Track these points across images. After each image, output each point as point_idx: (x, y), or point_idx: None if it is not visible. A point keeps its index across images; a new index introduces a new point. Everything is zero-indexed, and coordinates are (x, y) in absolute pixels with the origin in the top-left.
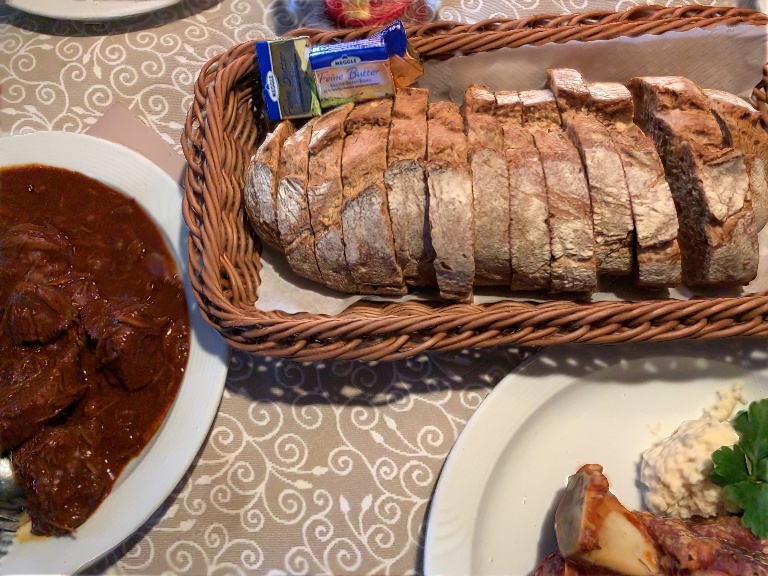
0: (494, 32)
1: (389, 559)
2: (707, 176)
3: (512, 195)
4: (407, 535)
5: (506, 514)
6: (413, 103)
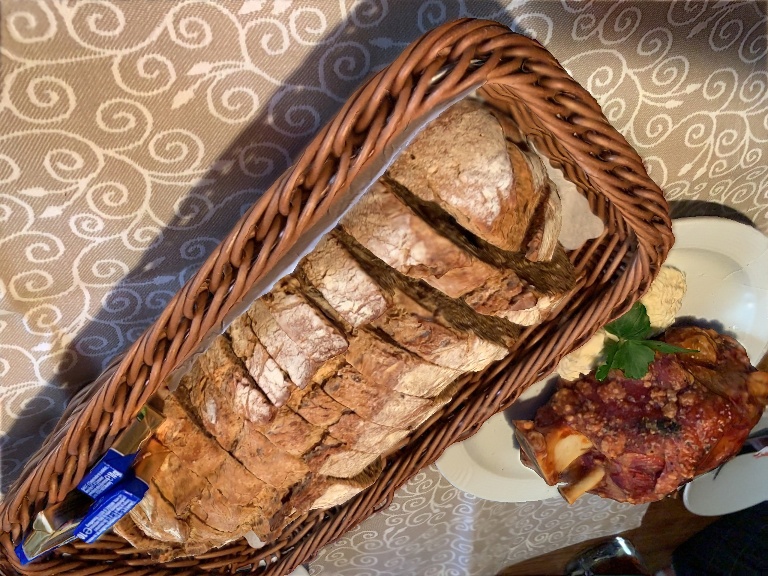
0: (175, 347)
1: (436, 484)
2: (508, 311)
3: None
4: (436, 472)
5: (483, 435)
6: (203, 458)
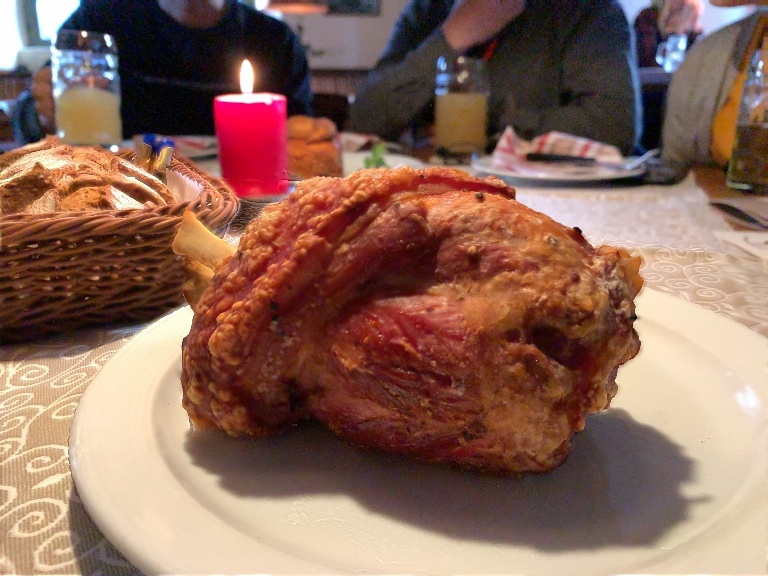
0: None
1: None
2: None
3: None
4: None
5: None
6: None
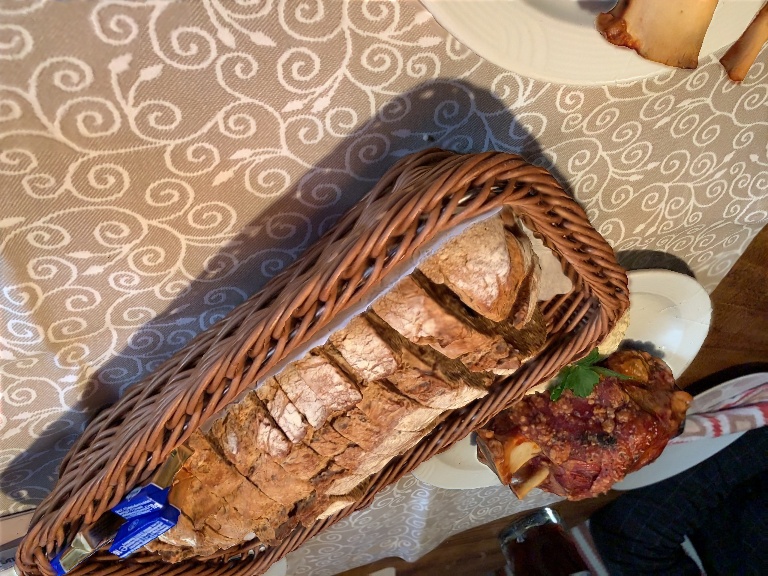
0: (215, 401)
1: None
2: None
3: None
4: None
5: None
6: (224, 483)
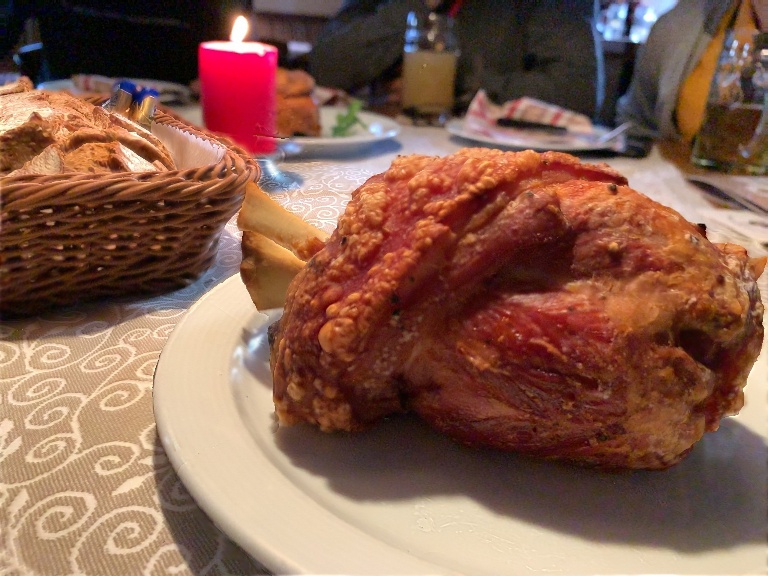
0: None
1: None
2: None
3: (4, 101)
4: None
5: None
6: None
